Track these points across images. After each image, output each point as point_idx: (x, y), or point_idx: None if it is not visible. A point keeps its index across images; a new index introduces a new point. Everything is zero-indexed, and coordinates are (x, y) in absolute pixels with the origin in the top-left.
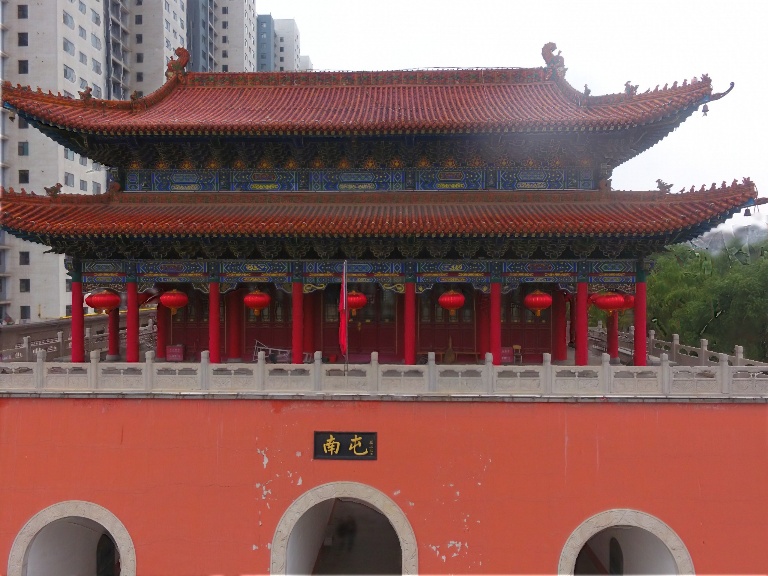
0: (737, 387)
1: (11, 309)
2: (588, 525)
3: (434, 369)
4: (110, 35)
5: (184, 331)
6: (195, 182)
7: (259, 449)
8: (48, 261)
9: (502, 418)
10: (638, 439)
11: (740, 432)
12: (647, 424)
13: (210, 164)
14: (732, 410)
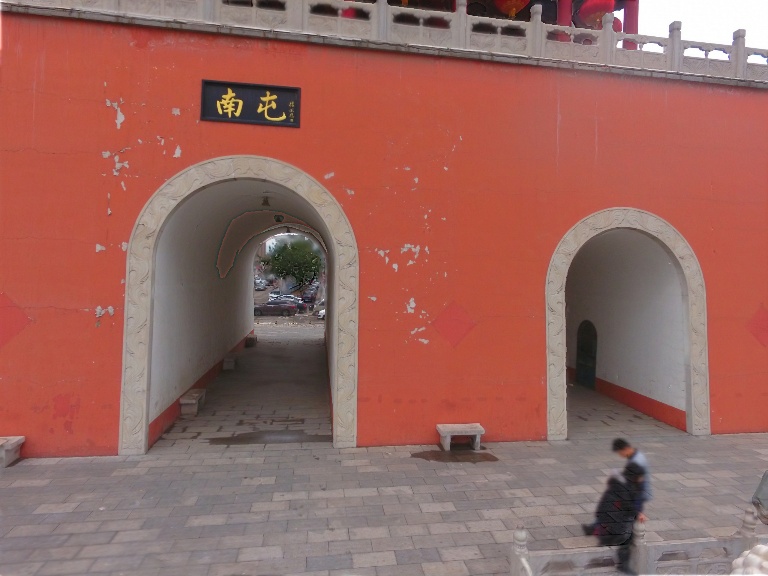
0: (752, 72)
1: None
2: (584, 226)
3: (385, 8)
4: None
5: None
6: None
7: (109, 100)
8: None
9: (477, 83)
10: (644, 123)
11: (755, 124)
12: (654, 105)
13: None
14: (747, 97)
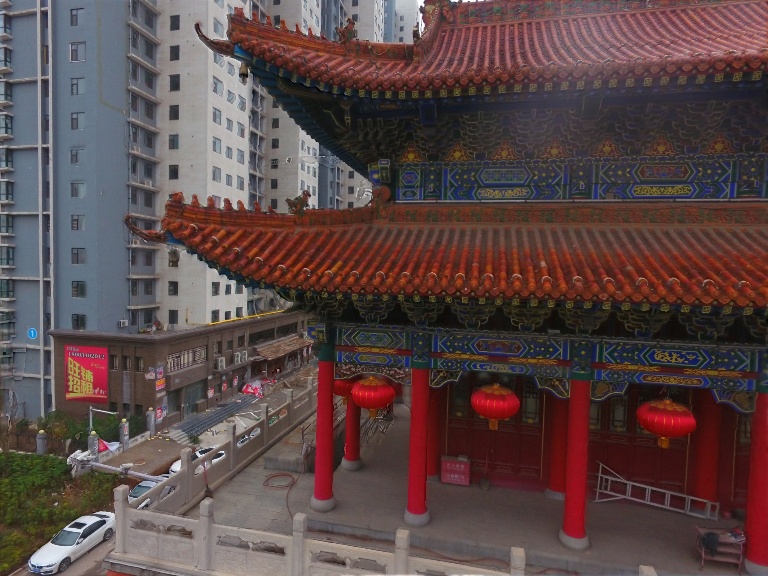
0: None
1: (160, 313)
2: None
3: None
4: None
5: (469, 433)
6: (523, 183)
7: None
8: (196, 263)
9: None
10: None
11: None
12: None
13: (550, 150)
14: None
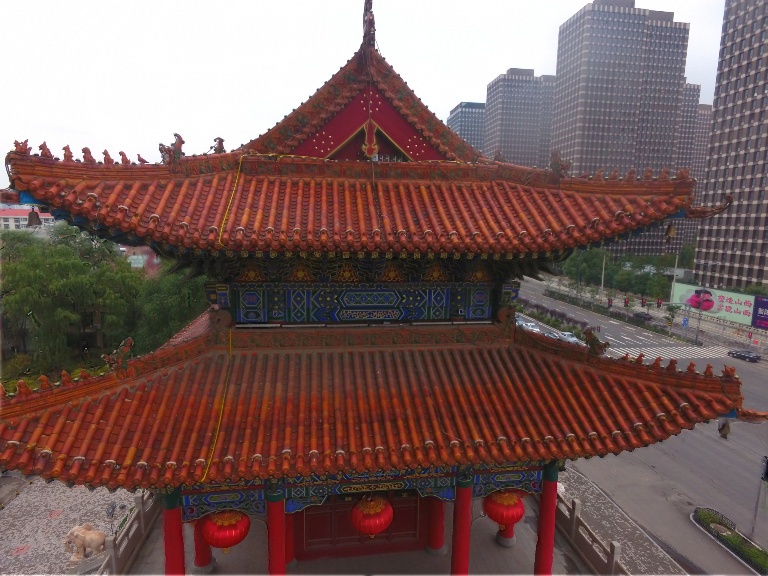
0: None
1: None
2: None
3: None
4: None
5: None
6: None
7: None
8: None
9: None
10: None
11: None
12: None
13: None
14: None
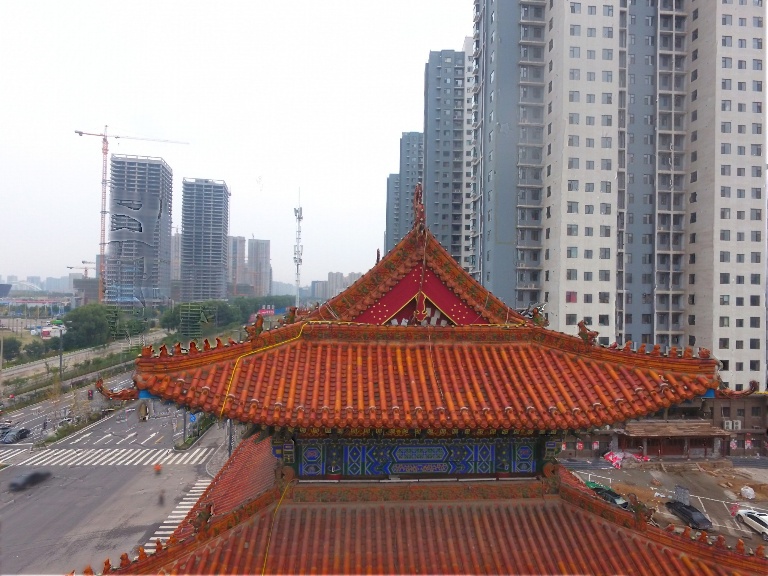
0: None
1: None
2: None
3: None
4: (657, 112)
5: None
6: None
7: None
8: None
9: None
10: None
11: None
12: None
13: None
14: None
